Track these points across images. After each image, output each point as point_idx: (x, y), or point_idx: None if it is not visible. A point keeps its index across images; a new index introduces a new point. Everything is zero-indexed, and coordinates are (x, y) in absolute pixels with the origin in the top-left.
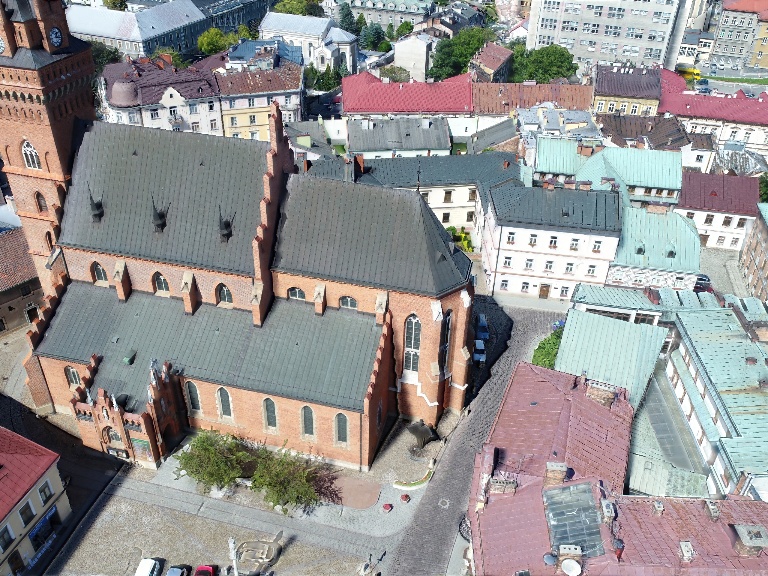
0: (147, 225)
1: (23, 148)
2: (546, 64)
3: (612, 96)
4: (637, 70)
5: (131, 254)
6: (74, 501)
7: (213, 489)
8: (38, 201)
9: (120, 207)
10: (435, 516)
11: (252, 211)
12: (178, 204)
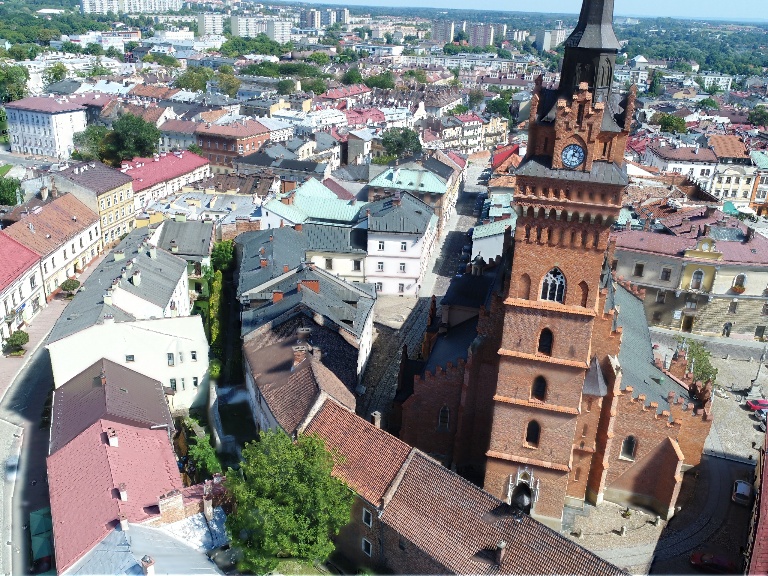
0: None
1: None
2: None
3: (107, 191)
4: None
5: None
6: None
7: None
8: None
9: None
10: None
11: None
12: None
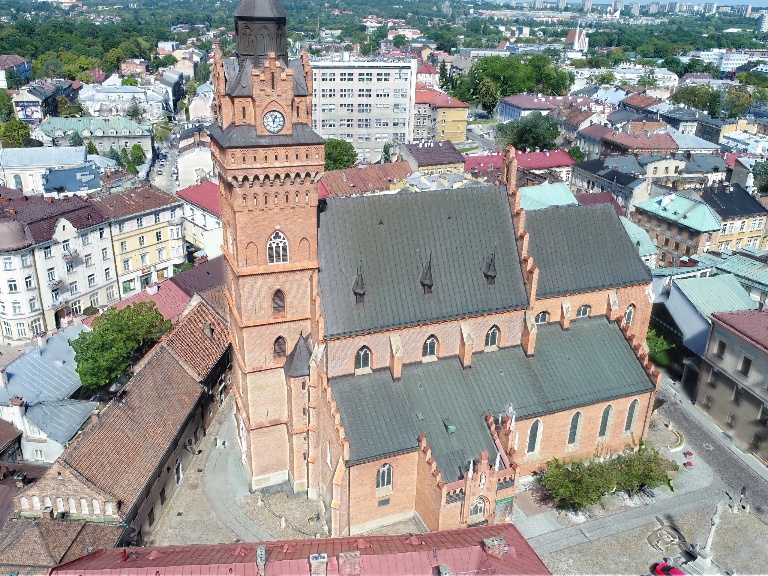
0: (414, 290)
1: (268, 241)
2: (336, 155)
3: (431, 165)
4: (434, 144)
5: (409, 323)
6: None
7: (572, 517)
8: (272, 302)
9: (380, 280)
10: (716, 456)
11: (506, 249)
12: (438, 261)
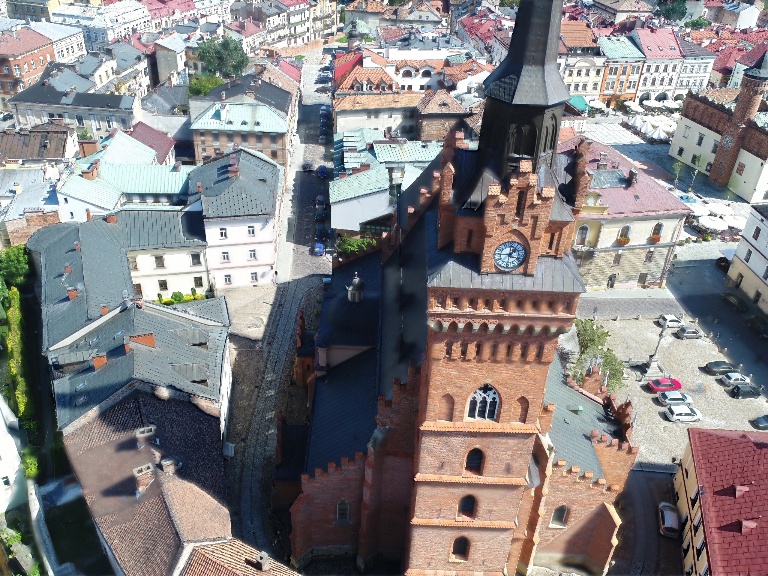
0: None
1: None
2: None
3: None
4: None
5: None
6: (664, 486)
7: None
8: None
9: None
10: None
11: None
12: None
